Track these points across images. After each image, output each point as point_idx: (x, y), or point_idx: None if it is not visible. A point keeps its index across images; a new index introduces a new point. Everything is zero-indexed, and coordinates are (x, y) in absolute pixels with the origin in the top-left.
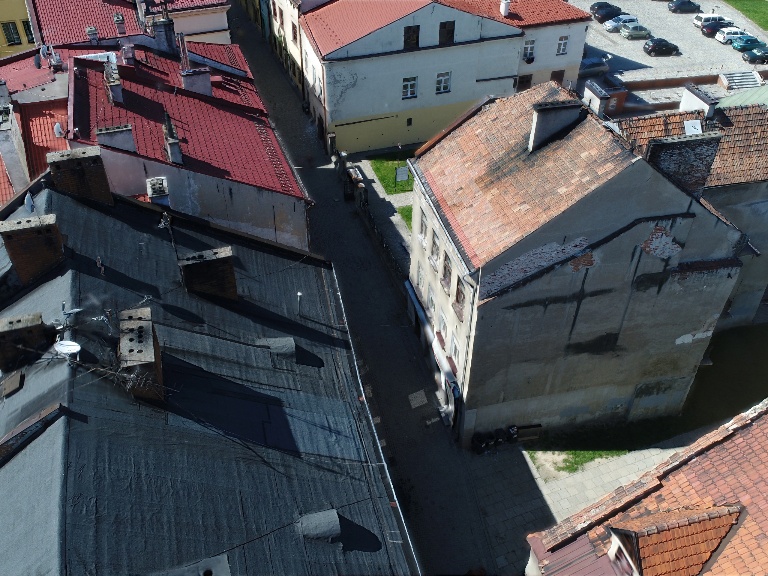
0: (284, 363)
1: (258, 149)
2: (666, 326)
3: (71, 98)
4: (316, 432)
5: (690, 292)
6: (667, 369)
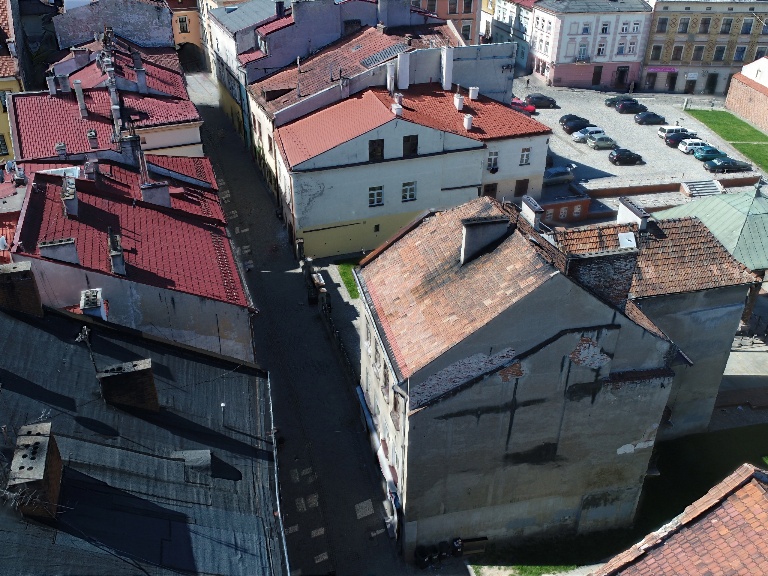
0: (198, 476)
1: (209, 258)
2: (605, 436)
3: (23, 212)
4: (220, 550)
5: (625, 402)
6: (612, 480)
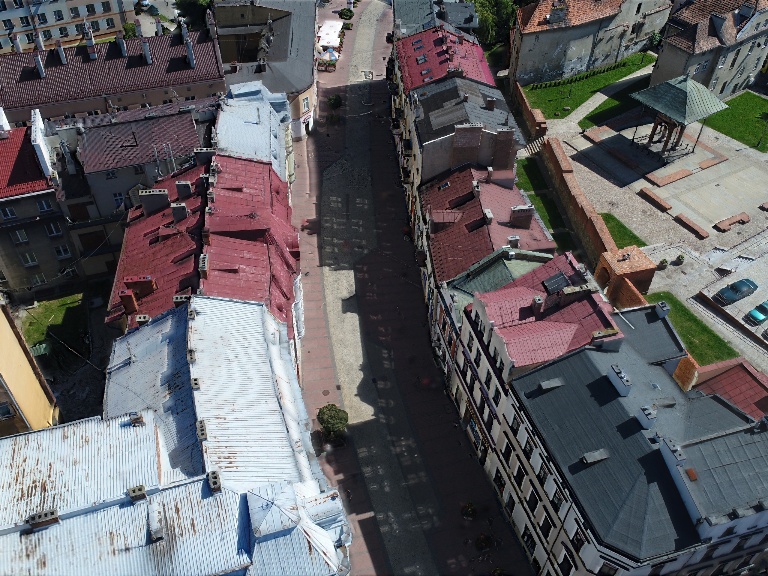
0: None
1: None
2: None
3: None
4: None
5: None
6: None
